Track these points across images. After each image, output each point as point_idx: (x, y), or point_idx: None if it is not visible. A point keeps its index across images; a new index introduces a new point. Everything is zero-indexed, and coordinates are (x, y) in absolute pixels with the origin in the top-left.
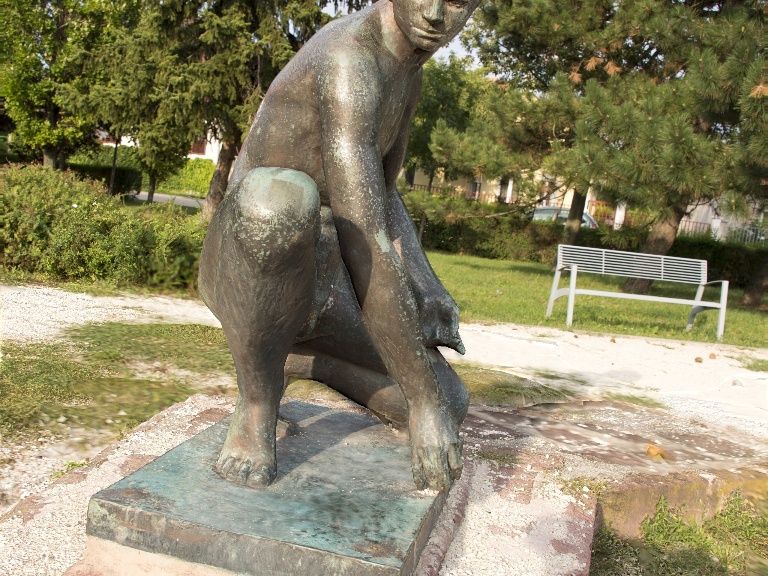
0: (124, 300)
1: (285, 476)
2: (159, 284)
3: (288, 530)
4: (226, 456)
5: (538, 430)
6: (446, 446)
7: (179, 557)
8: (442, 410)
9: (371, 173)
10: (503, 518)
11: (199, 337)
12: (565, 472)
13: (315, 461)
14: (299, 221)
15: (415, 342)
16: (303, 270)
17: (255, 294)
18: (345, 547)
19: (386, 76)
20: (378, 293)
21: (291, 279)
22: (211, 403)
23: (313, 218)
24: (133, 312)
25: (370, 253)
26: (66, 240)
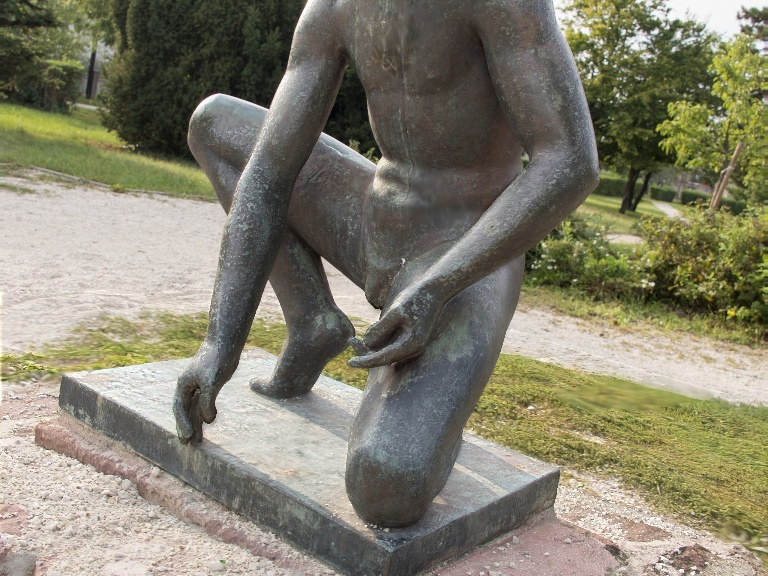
0: None
1: (273, 402)
2: None
3: (160, 369)
4: None
5: None
6: None
7: None
8: None
9: None
10: (206, 573)
11: None
12: None
13: (310, 425)
14: None
15: None
16: None
17: None
18: (114, 372)
19: None
20: None
21: None
22: (711, 547)
23: None
24: None
25: None
26: None
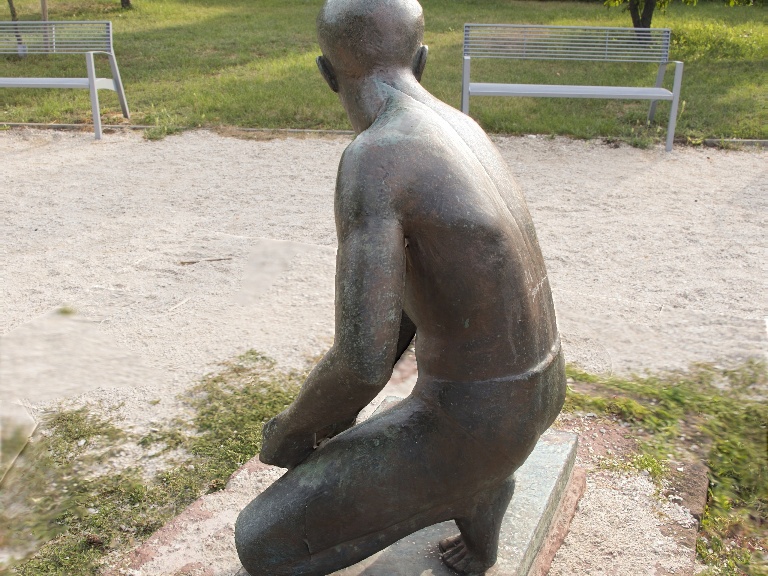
0: None
1: None
2: None
3: None
4: None
5: None
6: None
7: None
8: None
9: None
10: None
11: None
12: None
13: None
14: None
15: None
16: None
17: None
18: None
19: None
20: None
21: None
22: None
23: None
24: None
25: None
26: None
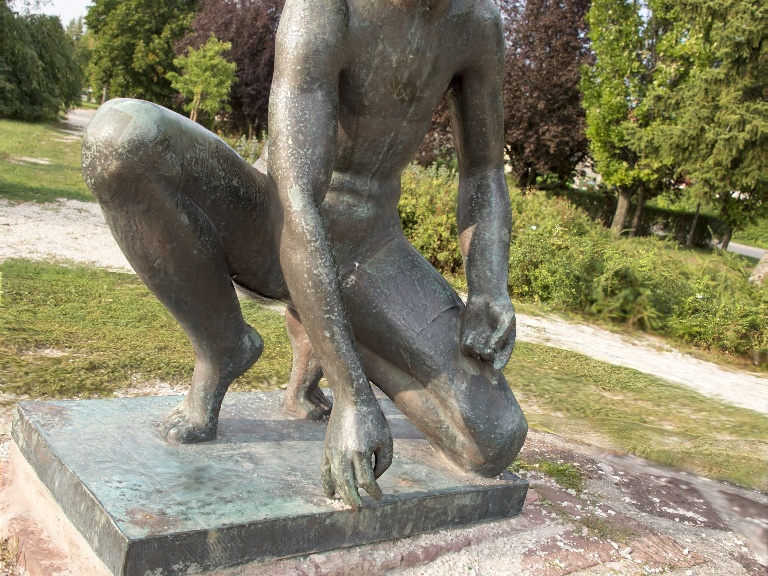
0: (539, 320)
1: (222, 443)
2: (596, 314)
3: (108, 476)
4: (177, 408)
5: (765, 531)
6: (349, 452)
7: (37, 473)
8: (358, 410)
9: (296, 121)
10: None
11: (553, 361)
12: (675, 573)
13: (287, 444)
14: (117, 150)
15: (323, 320)
16: (149, 208)
17: (113, 228)
18: (123, 505)
19: (365, 19)
20: (287, 256)
21: (140, 216)
22: None
23: (137, 149)
24: (527, 330)
25: (282, 210)
26: (517, 258)
